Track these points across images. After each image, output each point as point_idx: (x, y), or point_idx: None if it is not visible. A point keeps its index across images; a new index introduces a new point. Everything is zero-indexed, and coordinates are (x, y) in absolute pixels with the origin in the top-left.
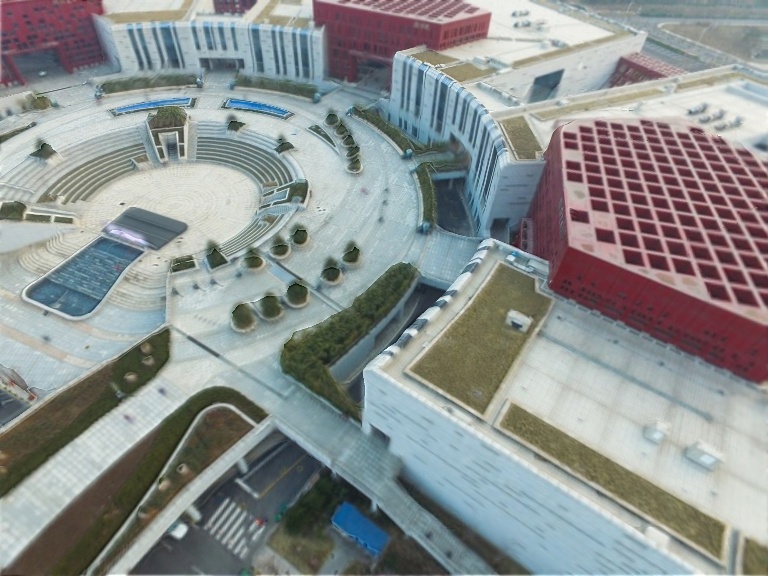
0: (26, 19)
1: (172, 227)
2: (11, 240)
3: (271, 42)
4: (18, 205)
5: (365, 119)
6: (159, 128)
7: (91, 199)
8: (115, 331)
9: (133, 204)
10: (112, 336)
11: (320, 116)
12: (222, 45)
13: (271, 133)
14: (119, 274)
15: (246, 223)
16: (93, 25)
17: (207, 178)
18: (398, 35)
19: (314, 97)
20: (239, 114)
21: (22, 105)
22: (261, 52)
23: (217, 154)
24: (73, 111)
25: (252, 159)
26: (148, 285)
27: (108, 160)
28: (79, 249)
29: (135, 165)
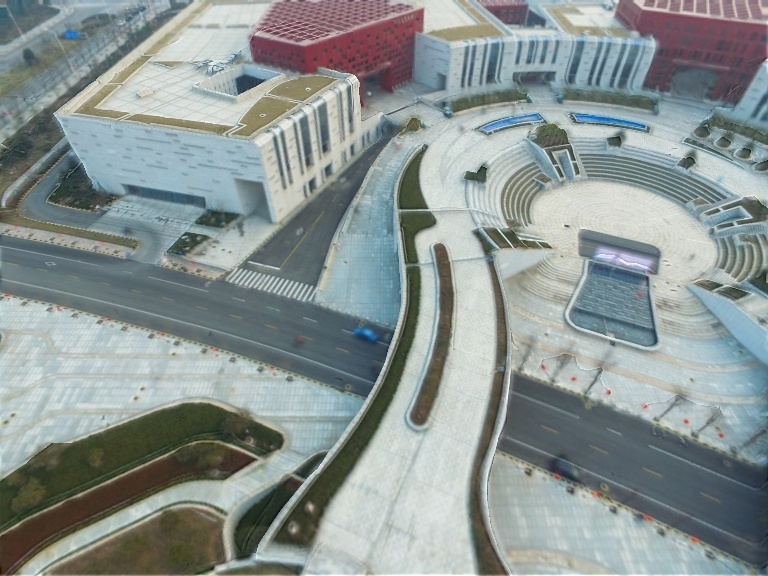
0: (377, 40)
1: (646, 249)
2: (513, 267)
3: (594, 54)
4: (512, 231)
5: (730, 130)
6: (549, 146)
7: (533, 222)
8: (701, 362)
9: (578, 226)
10: (703, 367)
11: (676, 128)
12: (541, 58)
13: (652, 148)
14: (648, 301)
15: (710, 243)
16: (414, 43)
17: (617, 196)
18: (747, 42)
19: (654, 108)
20: (598, 129)
21: (376, 126)
22: (578, 64)
23: (607, 171)
24: (442, 131)
25: (650, 175)
26: (686, 312)
27: (518, 181)
28: (583, 275)
29: (542, 185)
